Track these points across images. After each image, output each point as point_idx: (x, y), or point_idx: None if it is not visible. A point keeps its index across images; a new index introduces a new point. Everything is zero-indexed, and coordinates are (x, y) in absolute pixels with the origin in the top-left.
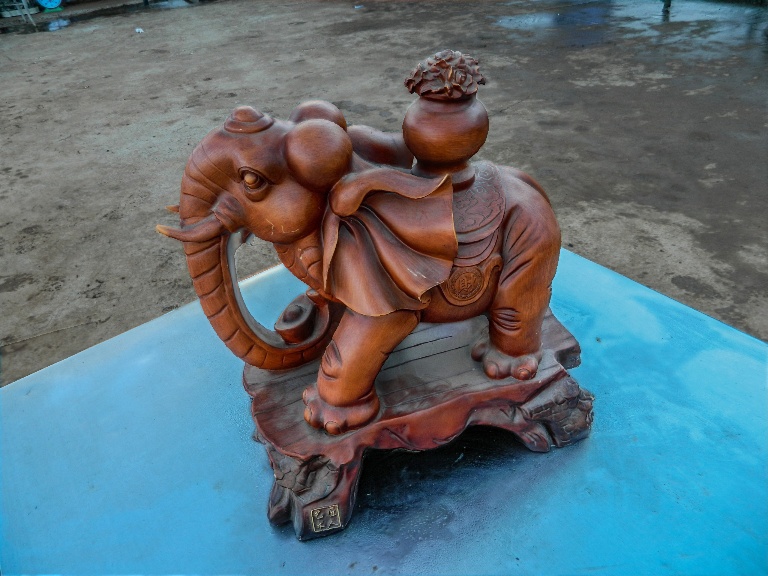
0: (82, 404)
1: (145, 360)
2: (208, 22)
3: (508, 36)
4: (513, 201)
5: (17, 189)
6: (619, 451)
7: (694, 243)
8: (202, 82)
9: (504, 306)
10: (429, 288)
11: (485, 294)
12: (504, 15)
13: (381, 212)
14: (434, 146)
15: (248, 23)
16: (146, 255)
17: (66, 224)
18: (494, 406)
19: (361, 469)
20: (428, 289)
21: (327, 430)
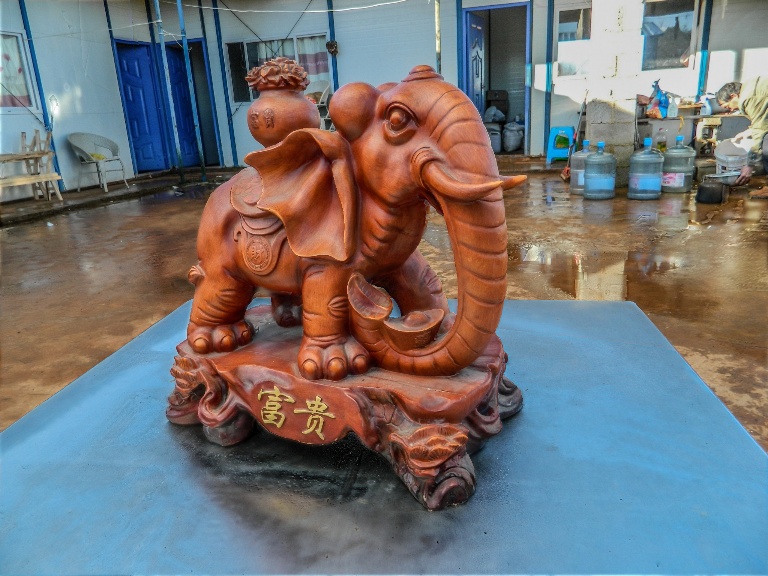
0: None
1: None
2: None
3: None
4: None
5: None
6: None
7: None
8: None
9: None
10: None
11: None
12: None
13: None
14: None
15: None
16: None
17: None
18: None
19: None
20: None
21: None
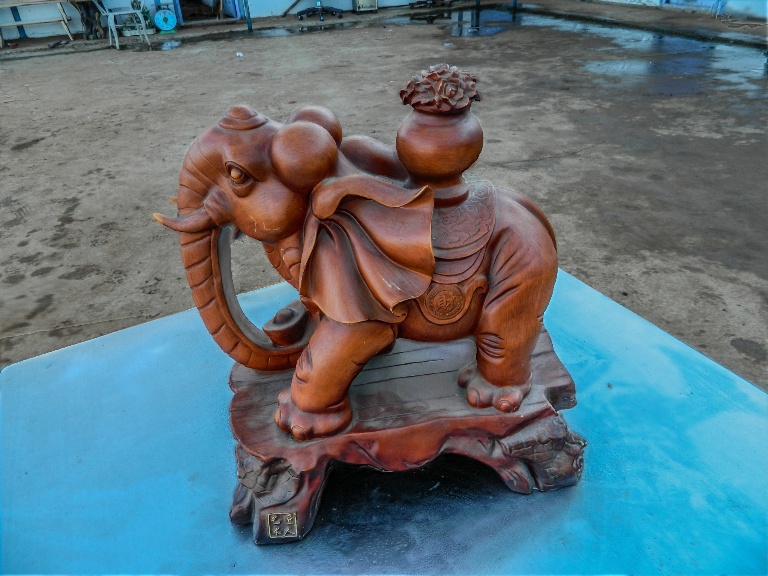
0: (92, 383)
1: (158, 350)
2: (303, 50)
3: (594, 80)
4: (504, 223)
5: (104, 188)
6: (606, 505)
7: (763, 306)
8: (287, 105)
9: (488, 331)
10: (402, 300)
11: (467, 316)
12: (593, 60)
13: (362, 219)
14: (421, 158)
15: (340, 53)
16: None
17: (139, 224)
18: (471, 436)
19: (326, 481)
20: (400, 301)
21: (293, 434)
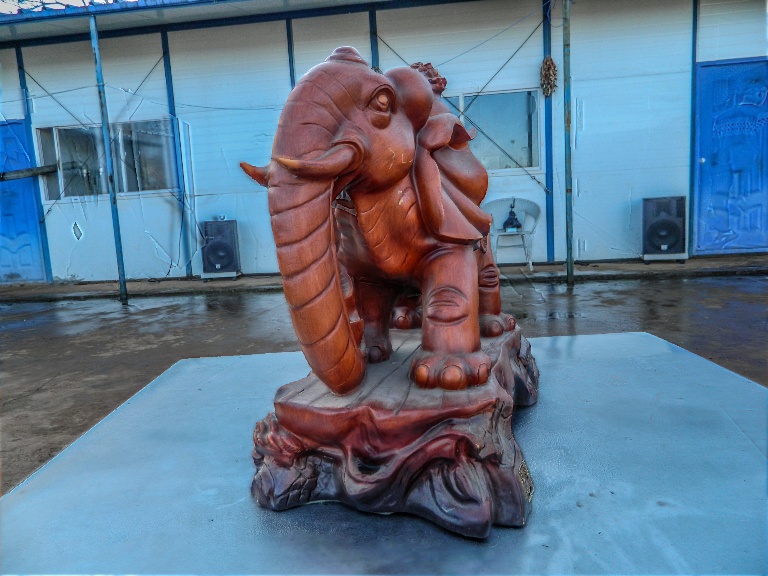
0: None
1: None
2: None
3: None
4: None
5: None
6: (559, 385)
7: None
8: None
9: (488, 264)
10: None
11: None
12: None
13: (439, 160)
14: None
15: None
16: None
17: None
18: (512, 356)
19: None
20: None
21: (480, 378)
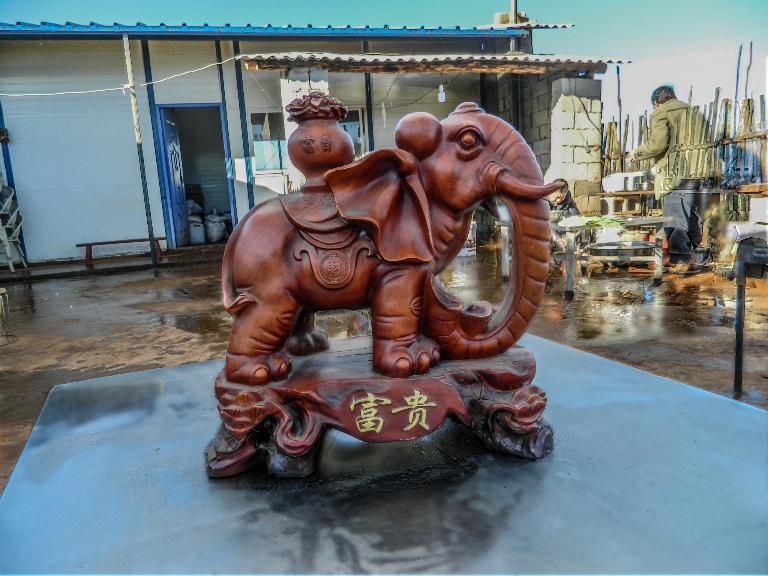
0: None
1: (761, 504)
2: None
3: None
4: None
5: None
6: None
7: None
8: None
9: None
10: None
11: None
12: None
13: None
14: None
15: None
16: None
17: None
18: None
19: None
20: None
21: None
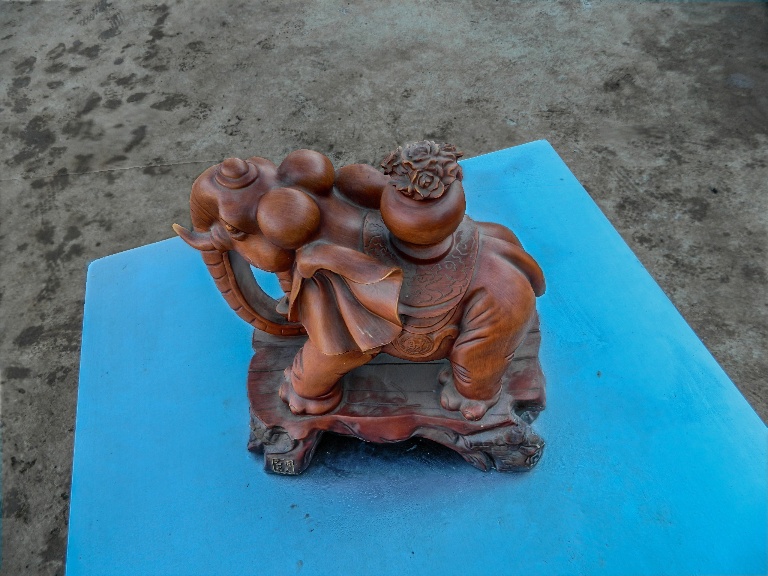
0: (157, 292)
1: None
2: None
3: None
4: (479, 283)
5: None
6: (548, 495)
7: None
8: None
9: (457, 363)
10: (371, 348)
11: (438, 352)
12: None
13: None
14: (396, 232)
15: None
16: (284, 98)
17: (224, 45)
18: (439, 429)
19: (319, 439)
20: None
21: (291, 410)
